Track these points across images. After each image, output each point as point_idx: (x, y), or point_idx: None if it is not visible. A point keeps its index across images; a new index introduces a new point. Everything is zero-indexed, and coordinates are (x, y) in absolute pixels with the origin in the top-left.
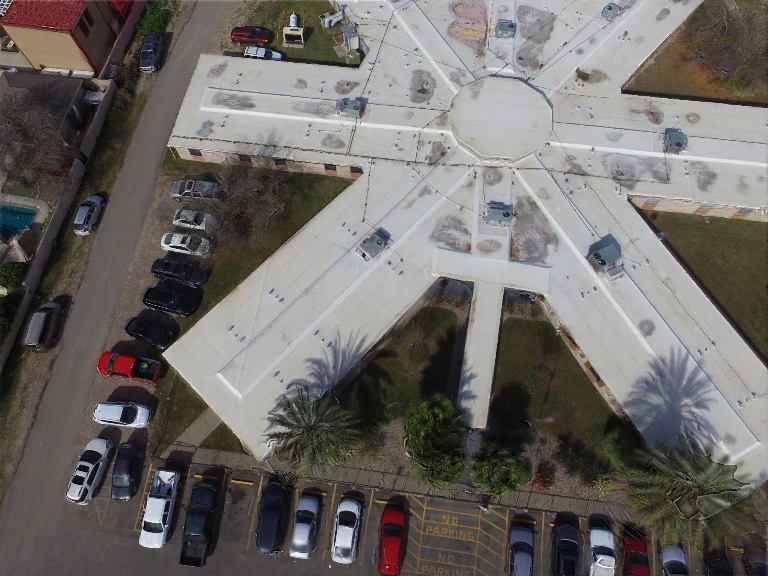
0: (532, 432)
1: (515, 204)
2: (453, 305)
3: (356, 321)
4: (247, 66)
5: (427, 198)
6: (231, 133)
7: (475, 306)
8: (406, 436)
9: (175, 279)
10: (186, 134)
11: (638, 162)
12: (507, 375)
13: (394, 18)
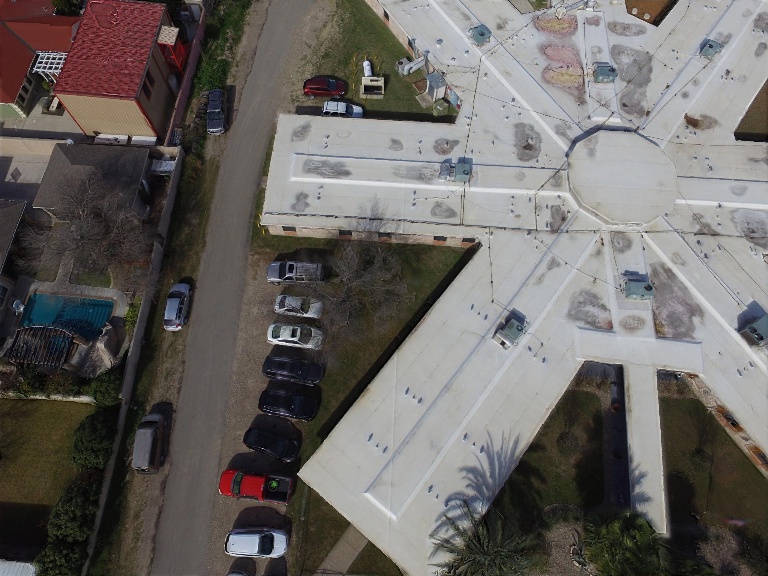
0: (702, 526)
1: (650, 272)
2: (594, 387)
3: (505, 419)
4: (333, 126)
5: (557, 271)
6: (329, 206)
7: (629, 393)
8: (574, 544)
9: (290, 379)
10: (280, 210)
11: (767, 217)
12: (664, 463)
13: (483, 64)
